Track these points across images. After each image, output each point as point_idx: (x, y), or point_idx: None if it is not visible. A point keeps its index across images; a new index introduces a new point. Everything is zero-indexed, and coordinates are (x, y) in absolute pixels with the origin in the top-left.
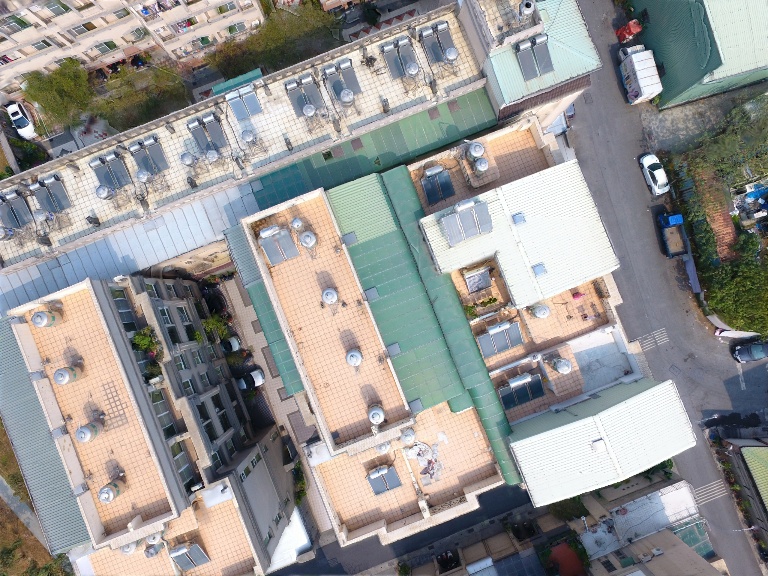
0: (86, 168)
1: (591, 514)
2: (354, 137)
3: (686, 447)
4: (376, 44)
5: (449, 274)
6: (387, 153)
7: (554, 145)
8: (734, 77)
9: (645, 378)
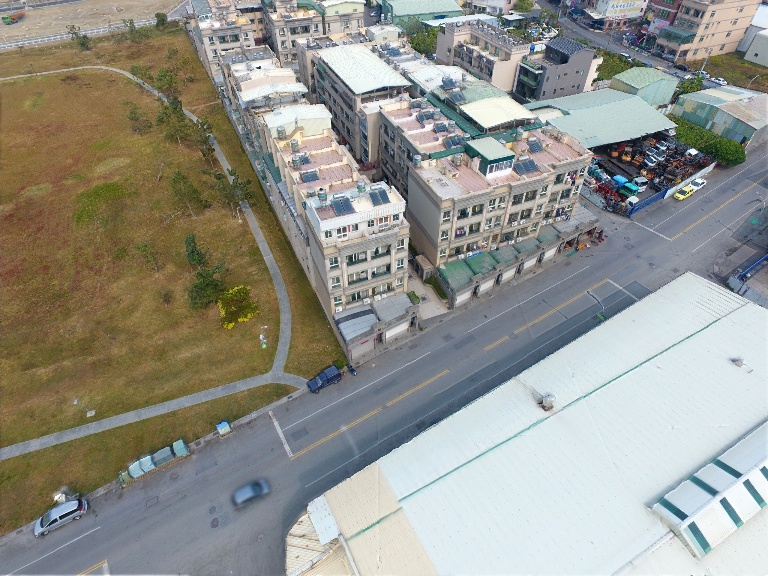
0: None
1: None
2: None
3: (363, 2)
4: None
5: None
6: None
7: None
8: None
9: None
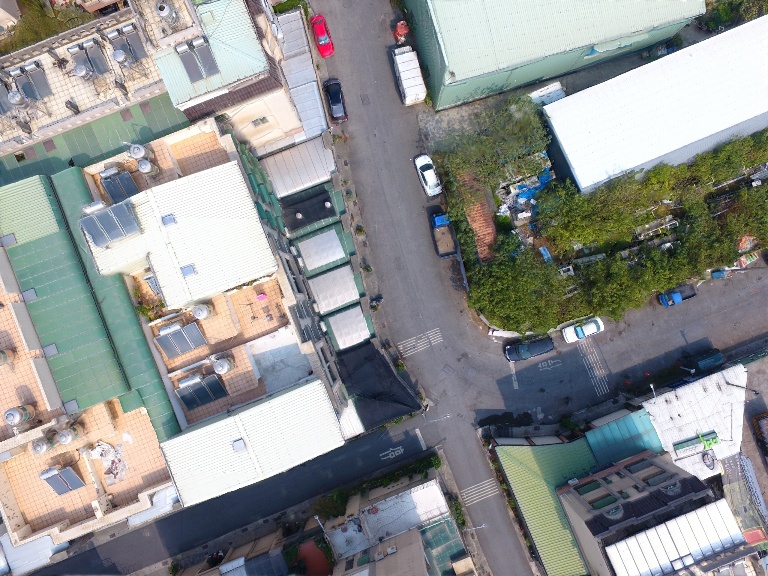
0: None
1: (345, 513)
2: (44, 139)
3: (333, 446)
4: (68, 46)
5: (121, 275)
6: (81, 155)
7: (231, 147)
8: (489, 78)
9: (315, 378)
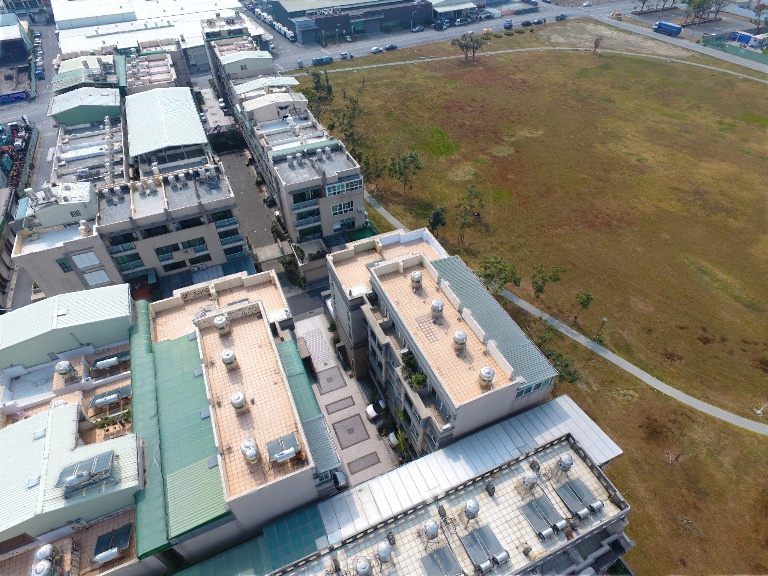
0: (517, 556)
1: None
2: None
3: None
4: None
5: None
6: None
7: None
8: None
9: (3, 368)
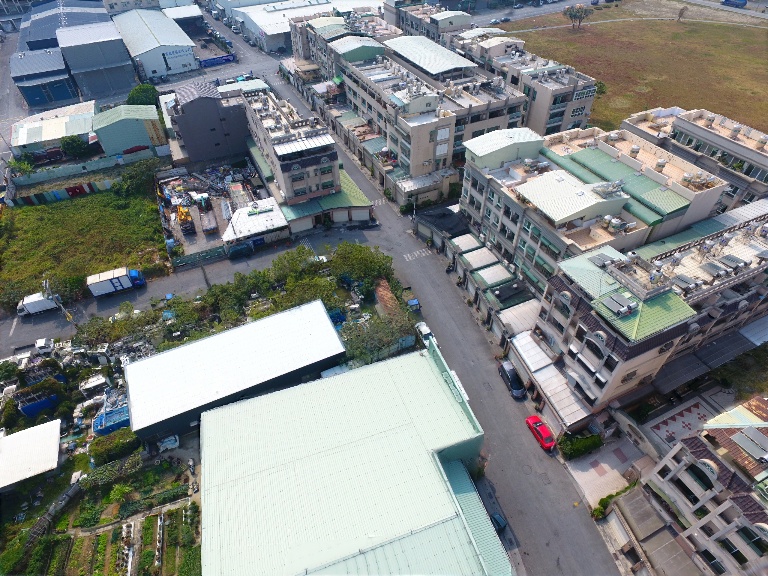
0: None
1: None
2: None
3: None
4: None
5: None
6: None
7: (565, 239)
8: None
9: None
